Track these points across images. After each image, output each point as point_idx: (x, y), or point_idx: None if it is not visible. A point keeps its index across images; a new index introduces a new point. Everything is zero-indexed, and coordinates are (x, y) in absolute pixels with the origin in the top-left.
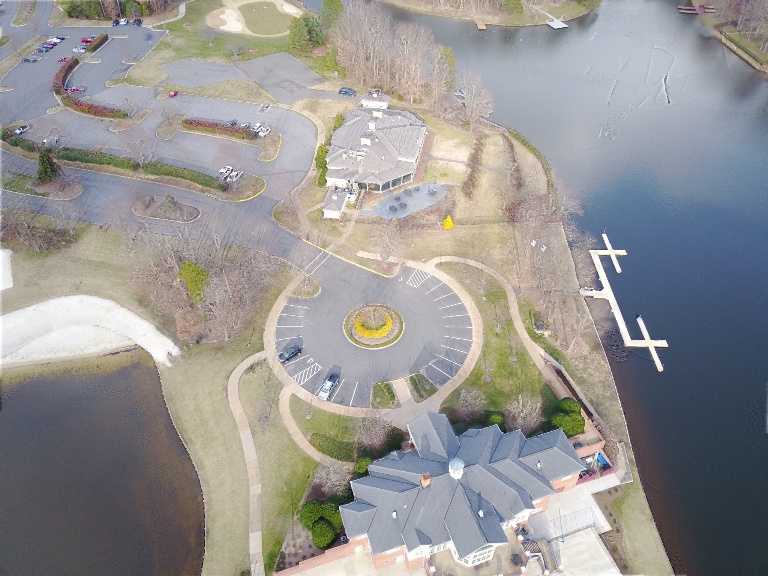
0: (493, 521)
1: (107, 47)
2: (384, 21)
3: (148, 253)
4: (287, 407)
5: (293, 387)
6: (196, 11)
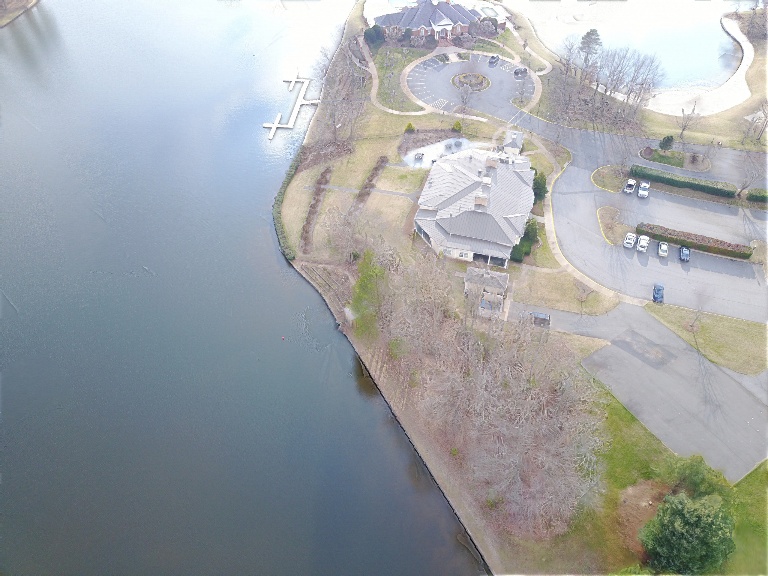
0: (421, 2)
1: None
2: None
3: None
4: (515, 56)
5: (514, 62)
6: None
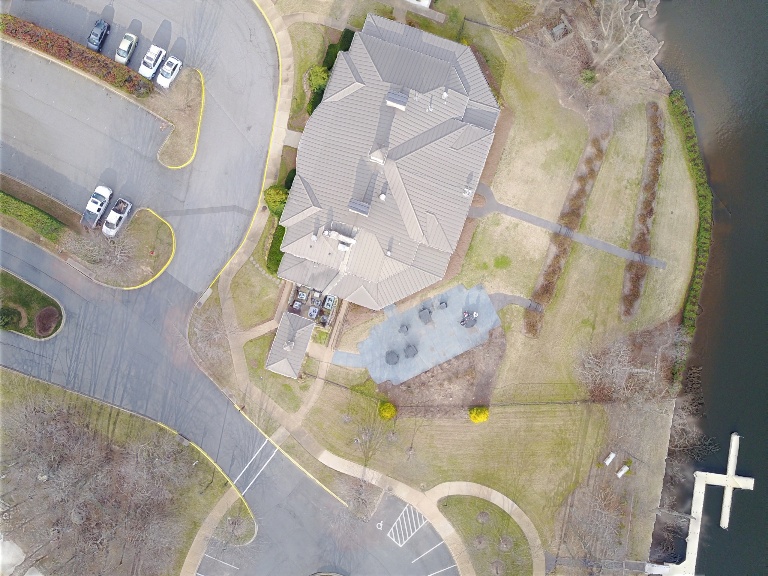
0: None
1: None
2: None
3: None
4: None
5: None
6: None
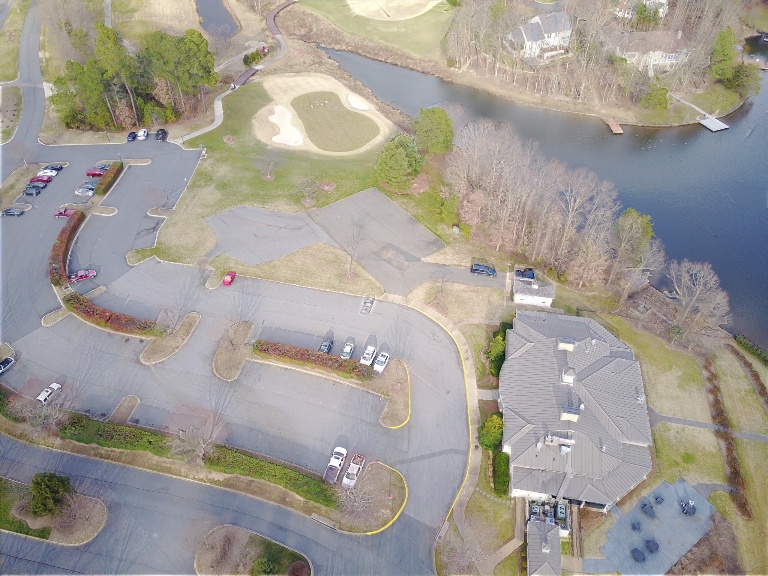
0: None
1: (123, 183)
2: (515, 147)
3: None
4: None
5: None
6: (237, 112)
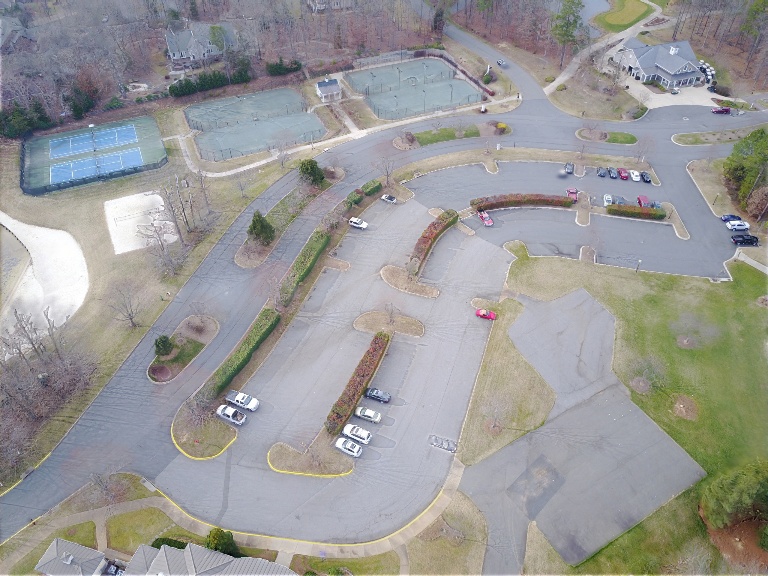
0: None
1: (634, 224)
2: None
3: (109, 343)
4: None
5: None
6: None
